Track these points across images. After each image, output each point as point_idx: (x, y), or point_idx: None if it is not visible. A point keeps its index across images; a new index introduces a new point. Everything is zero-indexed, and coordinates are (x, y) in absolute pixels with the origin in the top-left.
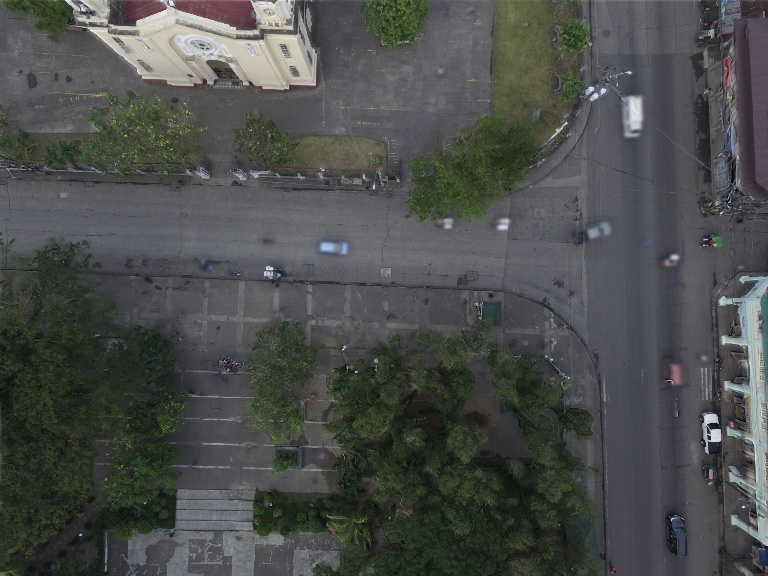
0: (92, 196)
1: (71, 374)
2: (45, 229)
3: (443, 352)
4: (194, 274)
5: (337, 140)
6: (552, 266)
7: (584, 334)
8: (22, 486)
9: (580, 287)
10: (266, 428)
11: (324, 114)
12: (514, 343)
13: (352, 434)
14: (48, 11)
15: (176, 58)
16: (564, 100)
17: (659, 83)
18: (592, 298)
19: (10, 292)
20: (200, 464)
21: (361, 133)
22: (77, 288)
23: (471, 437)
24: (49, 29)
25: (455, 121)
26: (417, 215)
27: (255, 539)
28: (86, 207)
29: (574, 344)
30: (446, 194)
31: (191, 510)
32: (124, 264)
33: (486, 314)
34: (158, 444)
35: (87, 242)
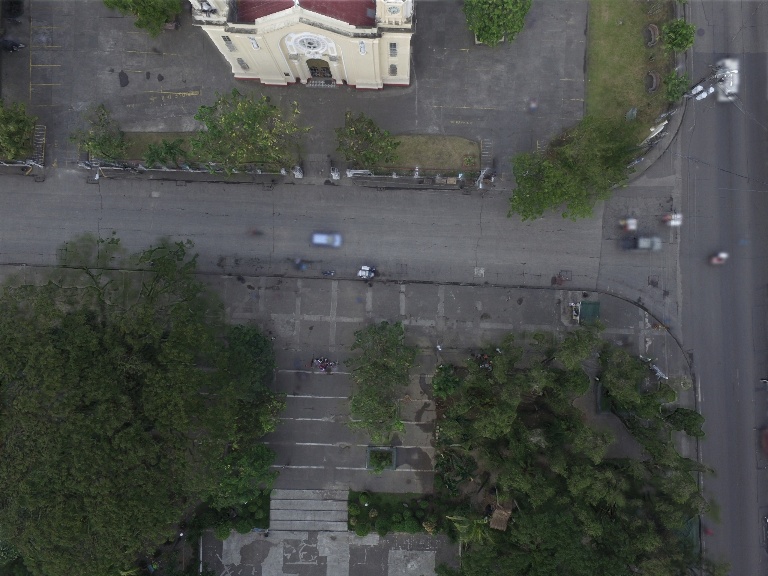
0: (184, 195)
1: (199, 374)
2: (137, 228)
3: (564, 352)
4: (287, 273)
5: (430, 139)
6: (646, 266)
7: (679, 334)
8: (153, 486)
9: (675, 287)
10: (370, 428)
11: (417, 113)
12: (608, 343)
13: (457, 434)
14: (148, 9)
15: (280, 57)
16: (669, 99)
17: (754, 82)
18: (687, 298)
19: (102, 291)
20: (293, 464)
21: (454, 132)
22: (192, 288)
23: (601, 438)
24: (147, 27)
25: (548, 120)
26: None
27: (350, 539)
28: (178, 206)
29: (669, 344)
30: (552, 193)
31: (285, 510)
32: (216, 263)
33: (584, 314)
34: (258, 444)
35: (191, 241)
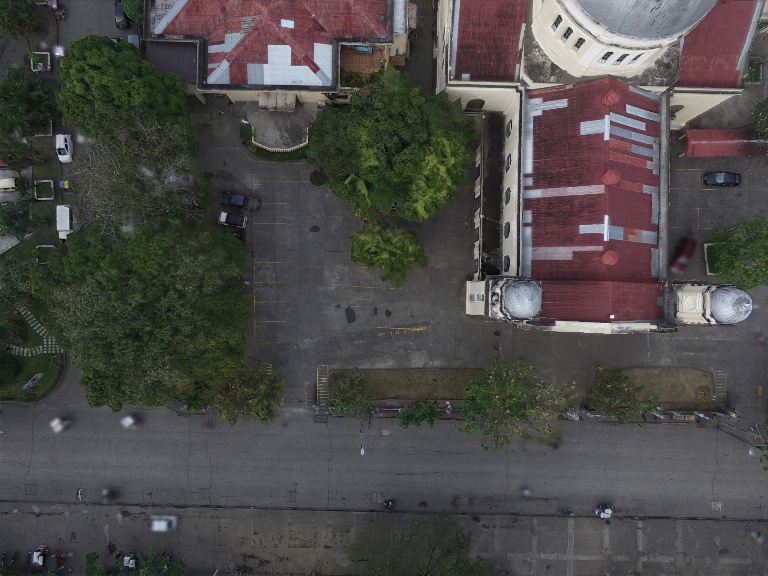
0: (415, 433)
1: None
2: (368, 468)
3: None
4: (522, 512)
5: (663, 371)
6: None
7: None
8: None
9: None
10: None
11: (649, 345)
12: None
13: None
14: (397, 265)
15: None
16: None
17: None
18: None
19: (333, 534)
20: None
21: (687, 364)
22: None
23: None
24: (392, 279)
25: None
26: (746, 447)
27: None
28: (409, 445)
29: None
30: None
31: None
32: (450, 503)
33: None
34: None
35: (454, 511)
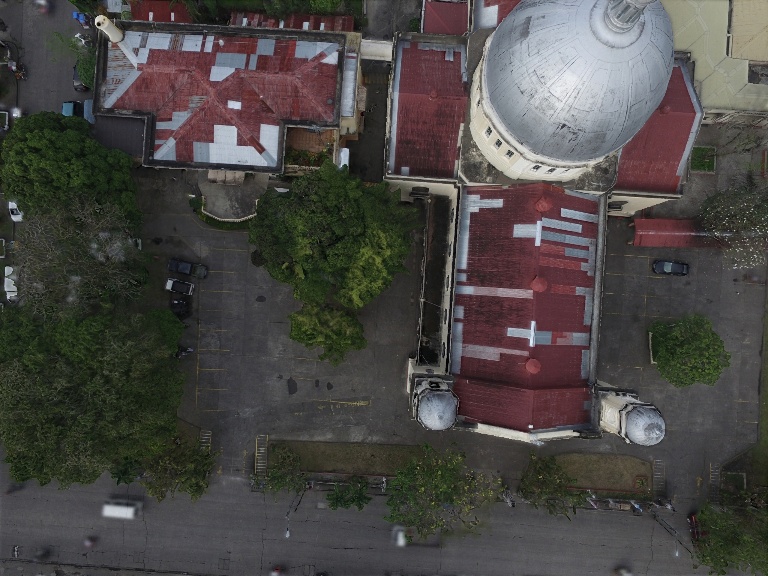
0: (351, 507)
1: None
2: (302, 540)
3: None
4: None
5: (602, 458)
6: None
7: None
8: None
9: None
10: None
11: None
12: None
13: None
14: (335, 346)
15: None
16: None
17: None
18: None
19: None
20: None
21: (626, 451)
22: None
23: None
24: (330, 358)
25: (722, 442)
26: (682, 538)
27: None
28: (344, 519)
29: None
30: (749, 562)
31: None
32: None
33: None
34: None
35: None
